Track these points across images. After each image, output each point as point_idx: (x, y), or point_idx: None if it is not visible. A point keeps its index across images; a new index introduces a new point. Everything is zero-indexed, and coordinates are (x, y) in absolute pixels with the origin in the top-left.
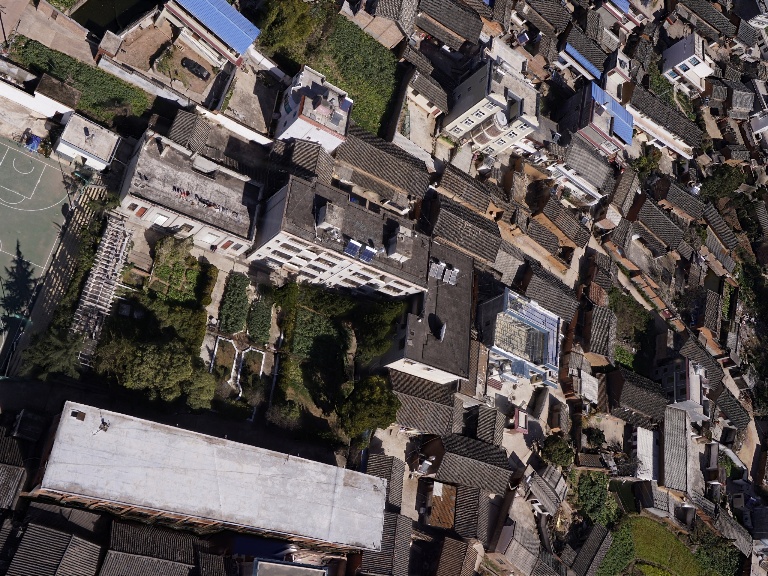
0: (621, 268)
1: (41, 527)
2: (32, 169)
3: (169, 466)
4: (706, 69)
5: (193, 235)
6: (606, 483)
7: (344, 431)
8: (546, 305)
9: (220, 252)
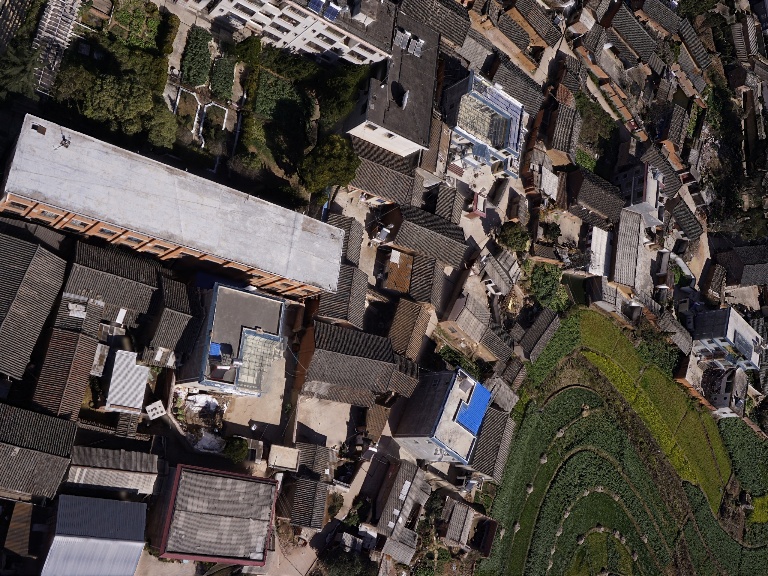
0: (591, 75)
1: (7, 236)
2: None
3: (131, 189)
4: None
5: None
6: (559, 276)
7: (305, 187)
8: None
9: (182, 4)
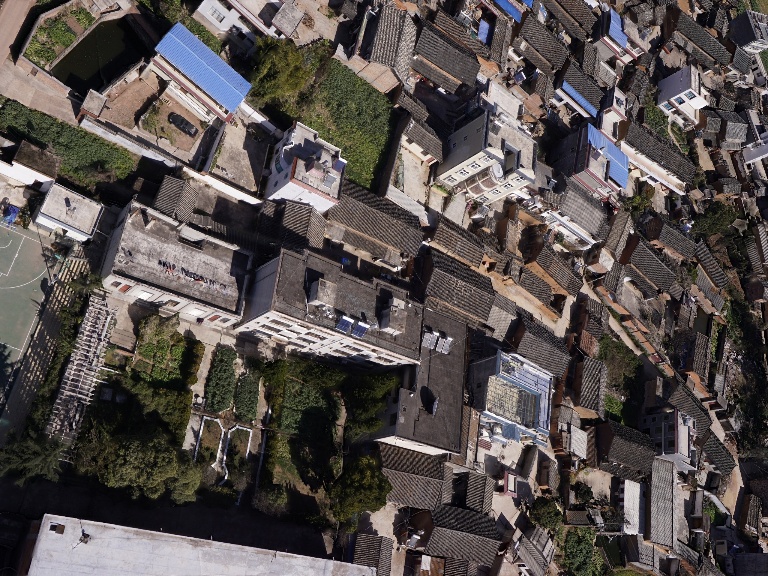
0: (612, 312)
1: None
2: (9, 242)
3: (152, 575)
4: (701, 101)
5: (179, 309)
6: (592, 538)
7: (332, 514)
8: (538, 361)
9: (207, 324)
